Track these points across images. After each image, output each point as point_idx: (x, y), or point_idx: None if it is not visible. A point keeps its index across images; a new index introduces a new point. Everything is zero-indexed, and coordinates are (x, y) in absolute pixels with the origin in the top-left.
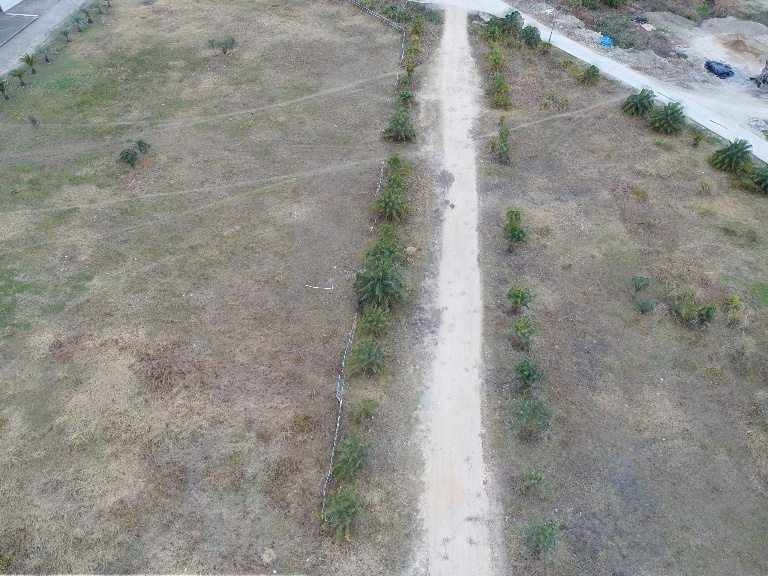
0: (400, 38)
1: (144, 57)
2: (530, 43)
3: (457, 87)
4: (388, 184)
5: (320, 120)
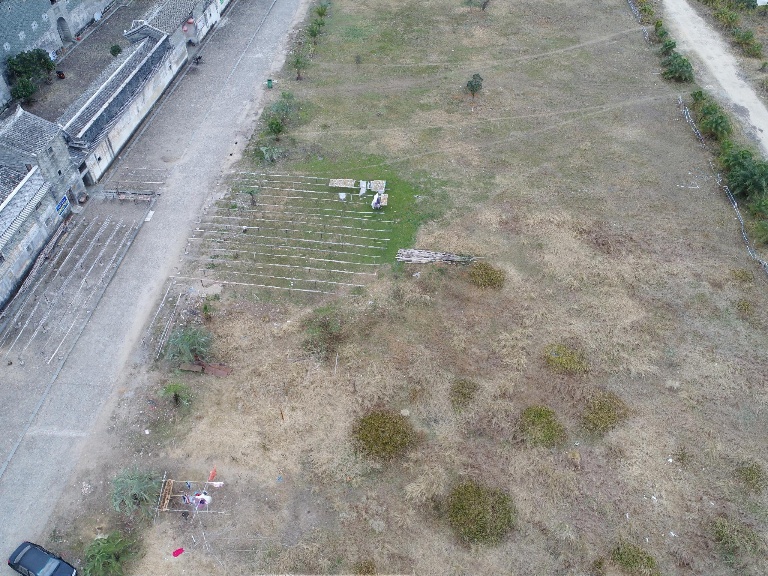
0: (624, 1)
1: (407, 13)
2: (748, 6)
3: (703, 40)
4: (706, 111)
5: (599, 65)
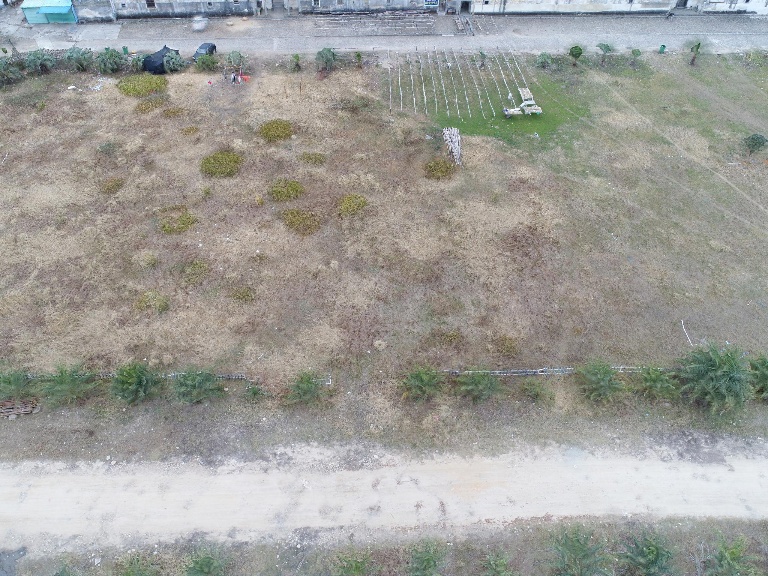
0: None
1: None
2: None
3: None
4: None
5: None
